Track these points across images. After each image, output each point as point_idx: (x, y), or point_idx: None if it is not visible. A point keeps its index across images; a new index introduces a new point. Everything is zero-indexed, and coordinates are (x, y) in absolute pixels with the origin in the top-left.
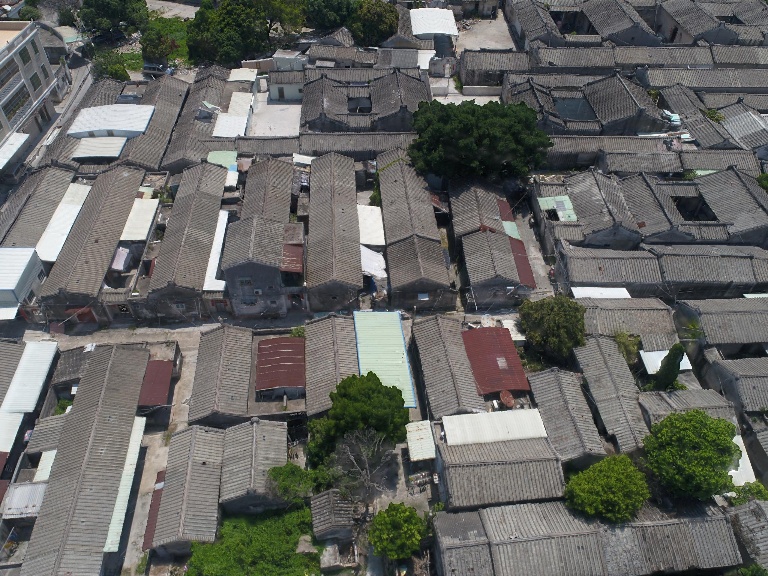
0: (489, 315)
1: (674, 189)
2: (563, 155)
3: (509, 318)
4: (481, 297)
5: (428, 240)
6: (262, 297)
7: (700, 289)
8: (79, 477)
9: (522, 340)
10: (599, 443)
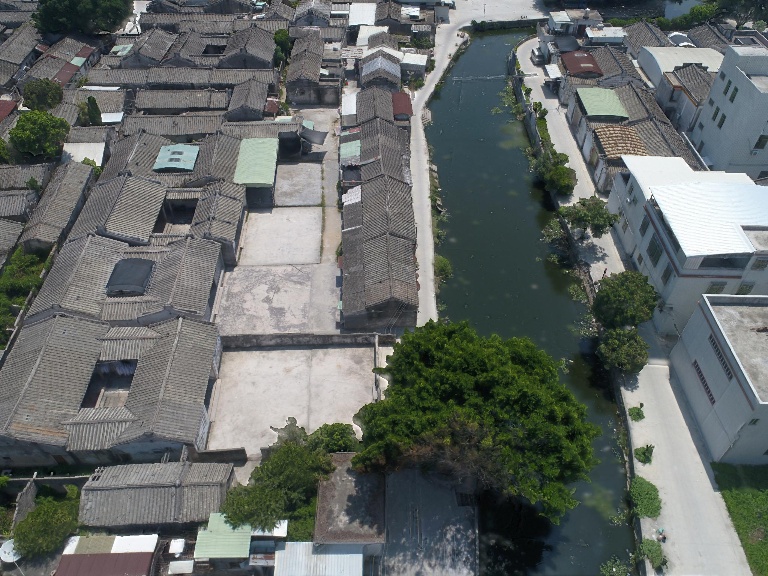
0: (8, 95)
1: (211, 40)
2: (163, 26)
3: None
4: None
5: (8, 63)
6: None
7: None
8: None
9: (28, 110)
10: None
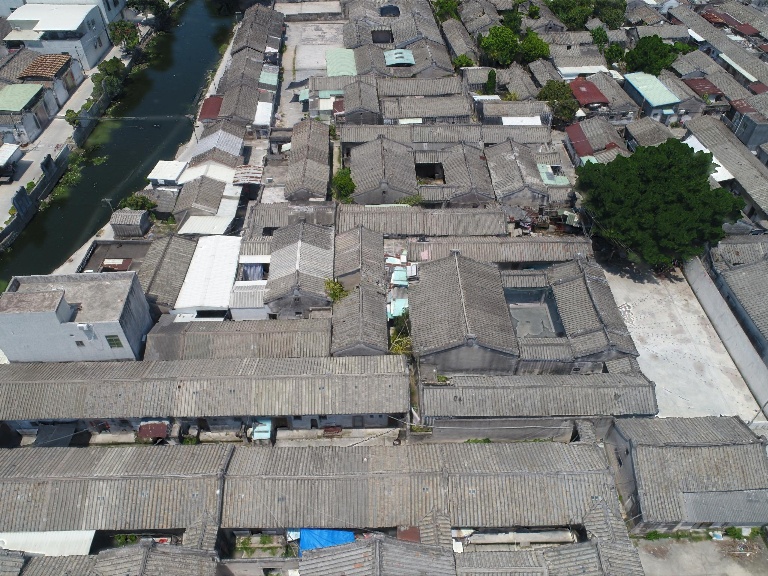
0: None
1: None
2: None
3: None
4: None
5: None
6: None
7: None
8: None
9: None
10: None
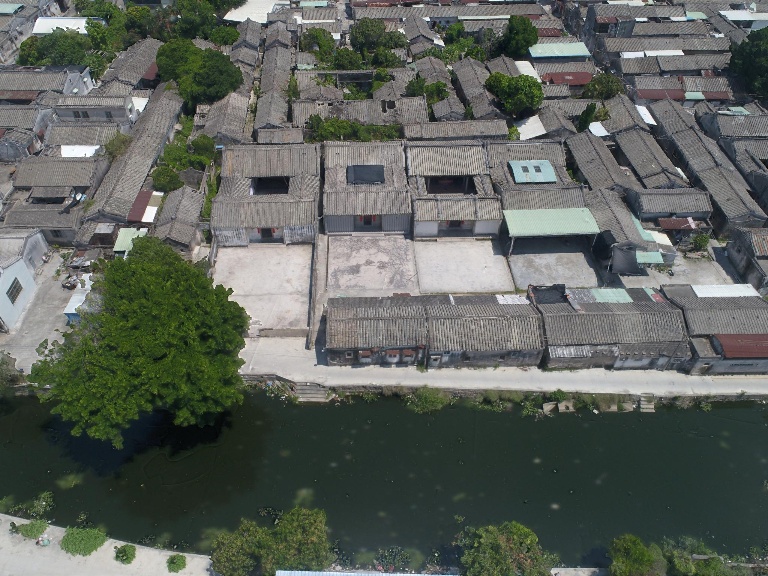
0: None
1: None
2: None
3: None
4: None
5: (658, 65)
6: (588, 33)
7: None
8: (481, 5)
9: None
10: None
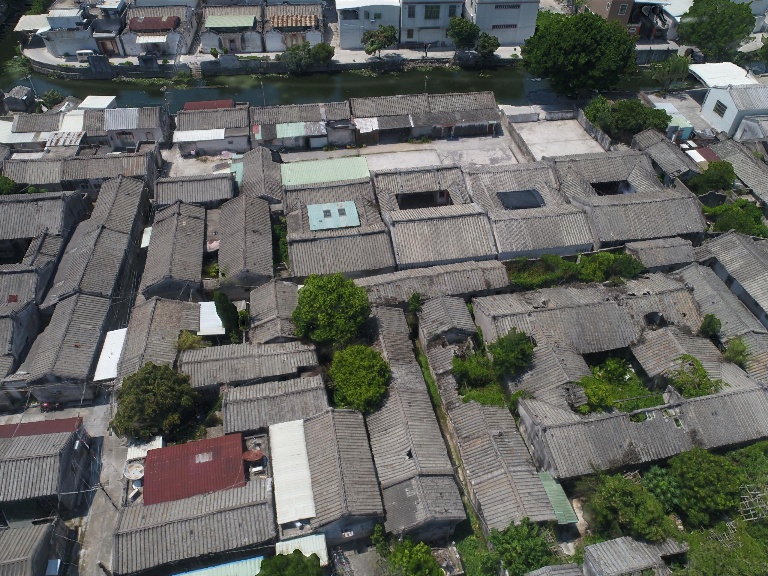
0: (125, 469)
1: None
2: None
3: (108, 461)
4: (71, 489)
5: None
6: None
7: (122, 276)
8: None
9: (162, 441)
10: (308, 379)
